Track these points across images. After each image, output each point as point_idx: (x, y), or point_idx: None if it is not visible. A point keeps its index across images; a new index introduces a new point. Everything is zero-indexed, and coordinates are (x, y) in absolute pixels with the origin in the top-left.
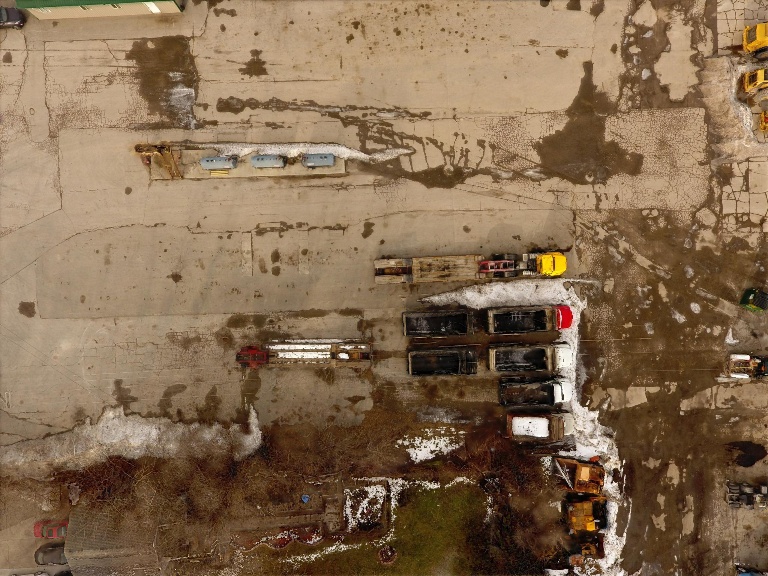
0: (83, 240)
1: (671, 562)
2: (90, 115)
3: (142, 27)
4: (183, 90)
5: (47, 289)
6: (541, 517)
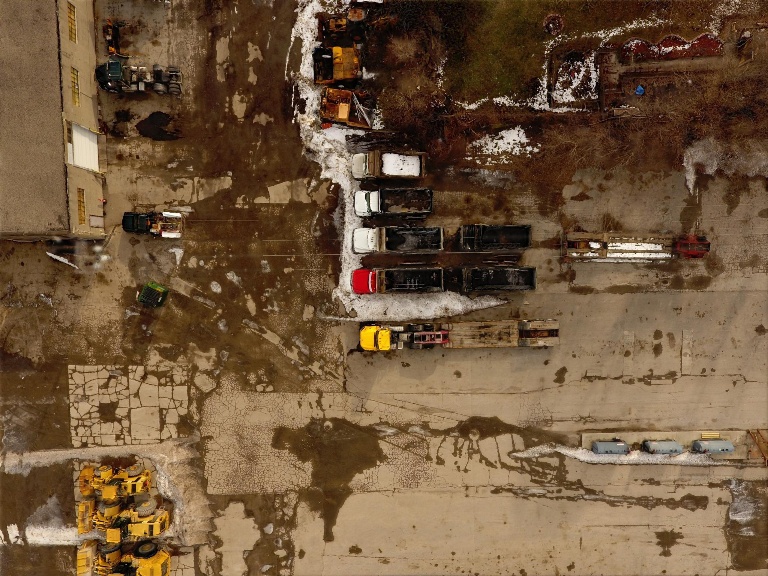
0: None
1: (241, 6)
2: None
3: None
4: (741, 518)
5: None
6: (384, 62)
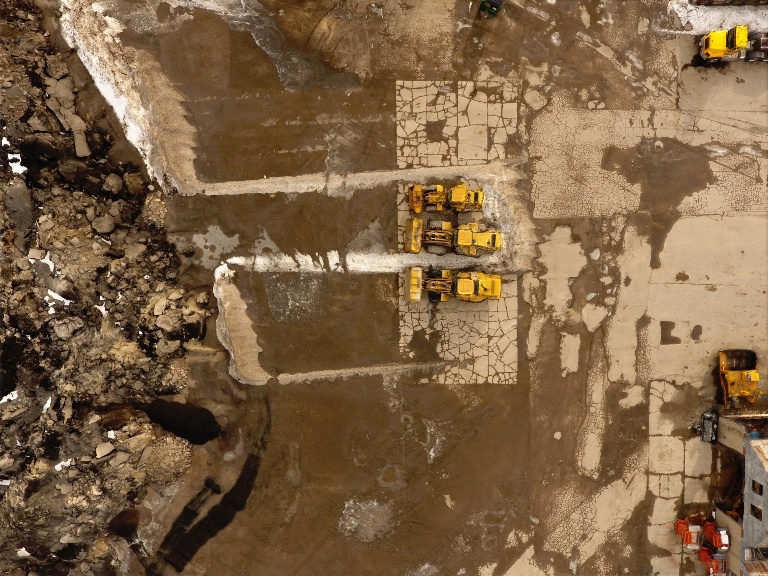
0: None
1: None
2: None
3: None
4: None
5: None
6: None
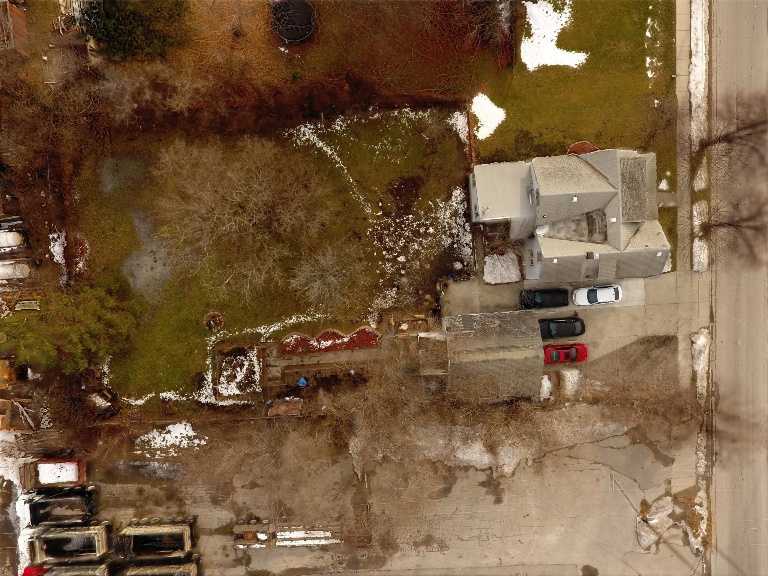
0: None
1: None
2: None
3: None
4: None
5: None
6: (49, 362)
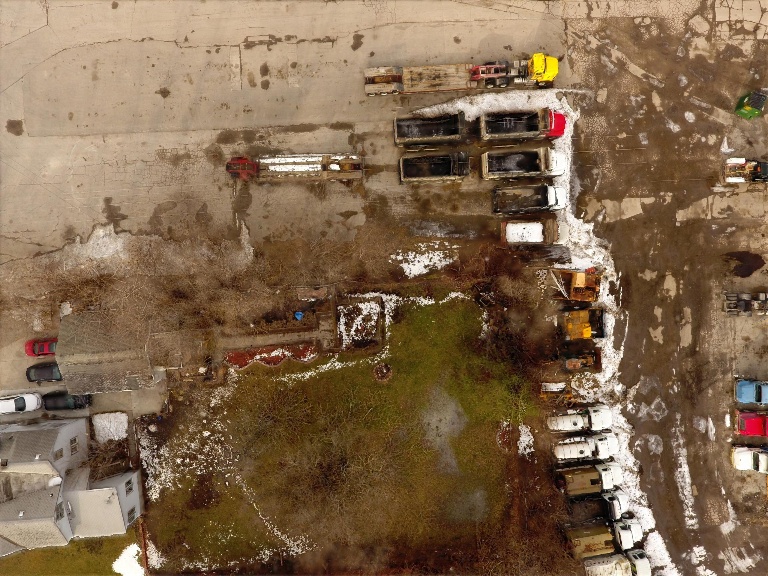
0: (70, 56)
1: (669, 375)
2: None
3: None
4: None
5: (34, 106)
6: (537, 332)
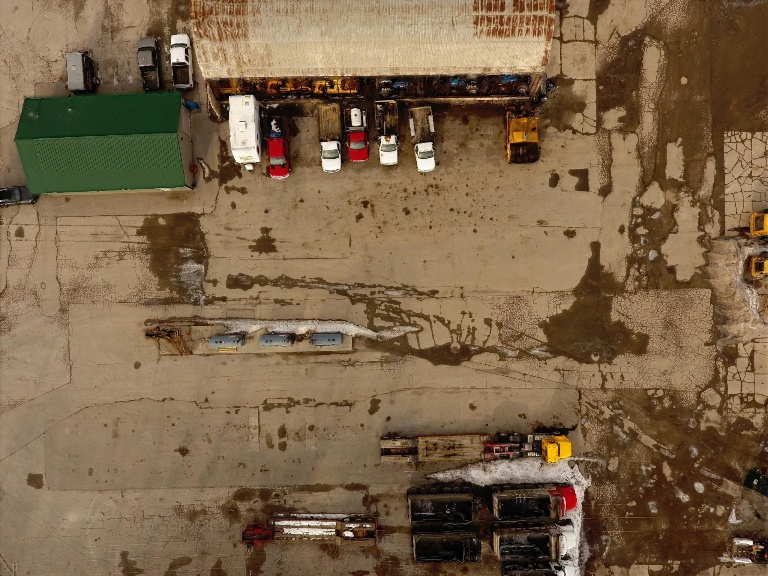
0: (92, 414)
1: None
2: (100, 290)
3: (153, 204)
4: (193, 266)
5: (55, 461)
6: None
